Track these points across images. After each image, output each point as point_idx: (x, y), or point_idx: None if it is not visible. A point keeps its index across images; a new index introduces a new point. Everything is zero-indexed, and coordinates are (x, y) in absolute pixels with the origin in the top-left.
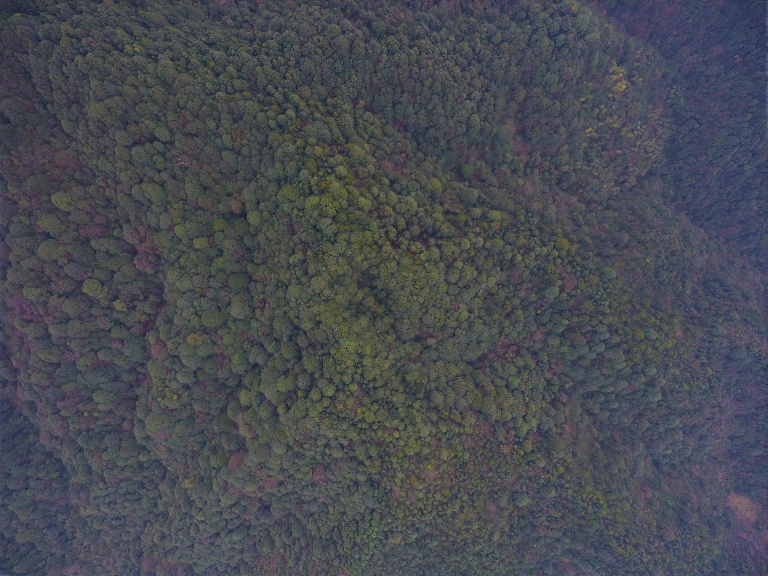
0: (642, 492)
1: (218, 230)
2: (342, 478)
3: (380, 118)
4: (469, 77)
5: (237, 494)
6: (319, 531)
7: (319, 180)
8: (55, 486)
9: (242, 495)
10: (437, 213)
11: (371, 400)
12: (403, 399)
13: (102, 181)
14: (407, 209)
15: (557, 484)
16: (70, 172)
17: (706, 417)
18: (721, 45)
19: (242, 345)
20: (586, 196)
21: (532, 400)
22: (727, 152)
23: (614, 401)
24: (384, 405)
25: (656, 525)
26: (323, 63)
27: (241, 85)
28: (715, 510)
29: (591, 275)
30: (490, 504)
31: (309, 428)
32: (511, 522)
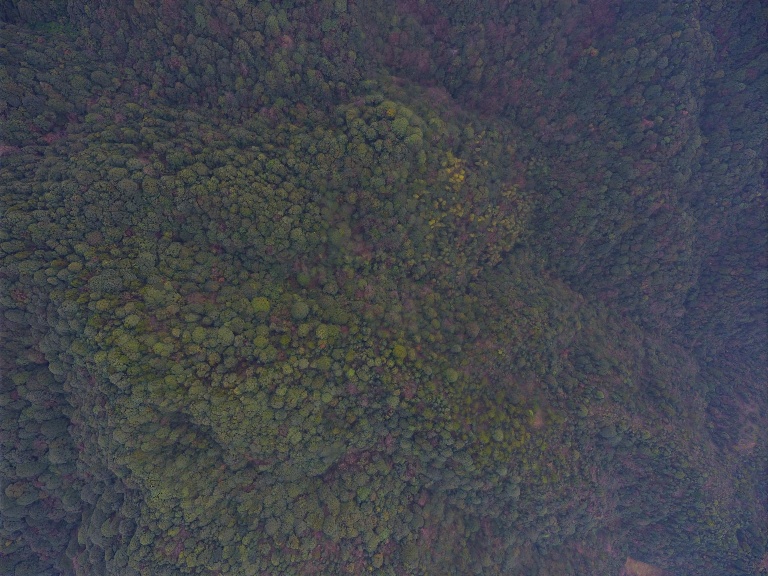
0: None
1: (20, 384)
2: None
3: (191, 246)
4: (284, 193)
5: None
6: None
7: (105, 335)
8: None
9: None
10: (258, 337)
11: (196, 540)
12: (230, 536)
13: None
14: (219, 342)
15: None
16: None
17: (581, 499)
18: (575, 115)
19: (72, 485)
20: (440, 285)
21: (386, 508)
22: (589, 223)
23: (476, 498)
24: (210, 544)
25: None
26: (111, 207)
27: (12, 247)
28: None
29: (430, 382)
30: None
31: None
32: None
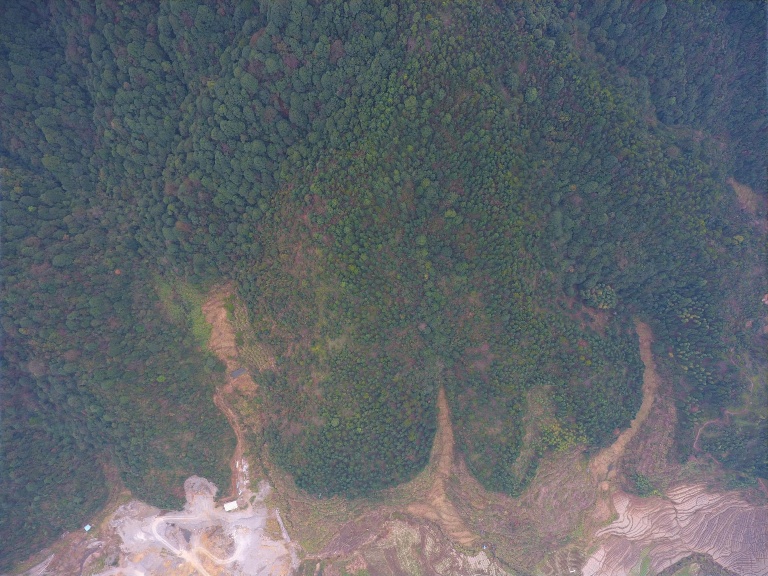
0: (647, 122)
1: None
2: (359, 47)
3: None
4: None
5: (257, 82)
6: (336, 127)
7: None
8: (80, 113)
9: (262, 87)
10: None
11: None
12: None
13: None
14: None
15: (566, 77)
16: None
17: (709, 63)
18: None
19: None
20: None
21: None
22: None
23: (621, 23)
24: None
25: None
26: None
27: None
28: None
29: None
30: (501, 86)
31: None
32: (521, 115)
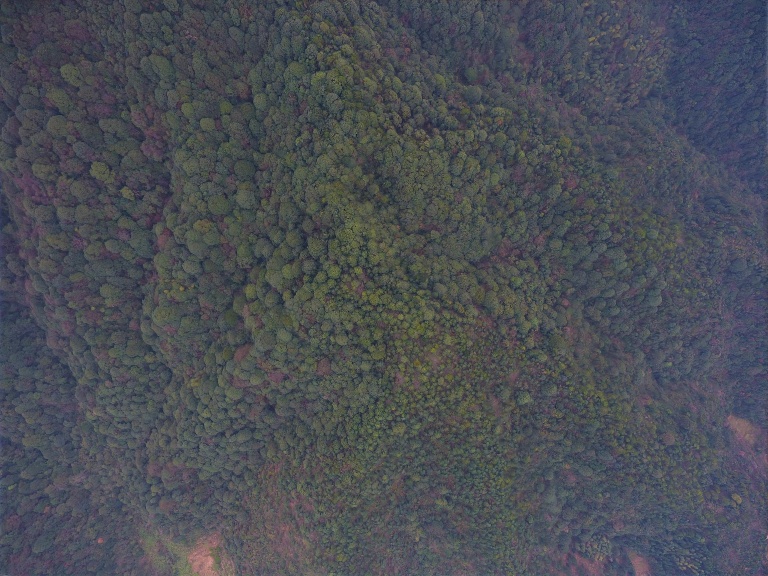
0: (642, 400)
1: (225, 113)
2: (346, 369)
3: (385, 11)
4: None
5: (242, 390)
6: (323, 429)
7: (325, 56)
8: (62, 391)
9: (247, 392)
10: (441, 106)
11: (376, 285)
12: (407, 285)
13: (111, 56)
14: (412, 97)
15: (559, 382)
16: (79, 45)
17: (706, 329)
18: None
19: (248, 237)
20: (588, 108)
21: (534, 301)
22: (729, 70)
23: (615, 307)
24: (388, 290)
25: (656, 431)
26: None
27: None
28: (714, 425)
29: (593, 174)
30: (492, 399)
31: (314, 309)
32: (513, 420)
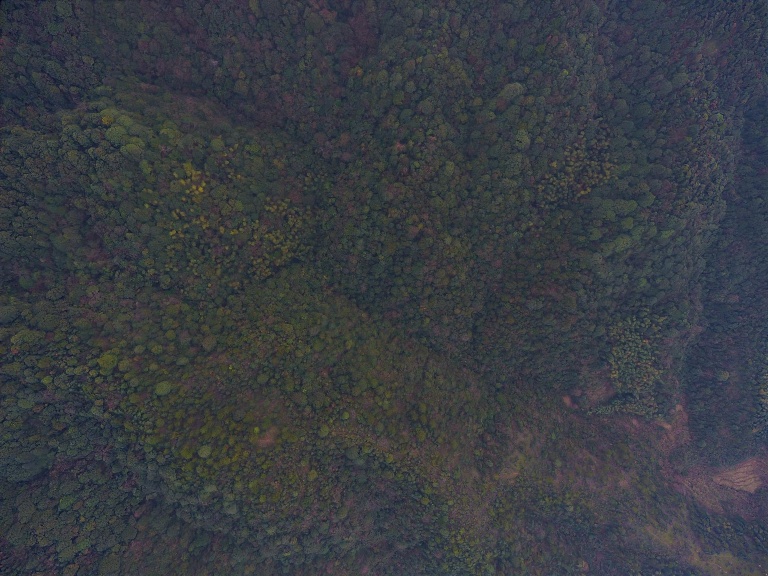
0: None
1: None
2: None
3: None
4: None
5: None
6: None
7: None
8: None
9: None
10: None
11: None
12: None
13: None
14: None
15: None
16: None
17: (321, 519)
18: (348, 133)
19: None
20: (188, 296)
21: (94, 518)
22: (356, 242)
23: (197, 512)
24: None
25: None
26: None
27: None
28: None
29: (133, 394)
30: None
31: None
32: None
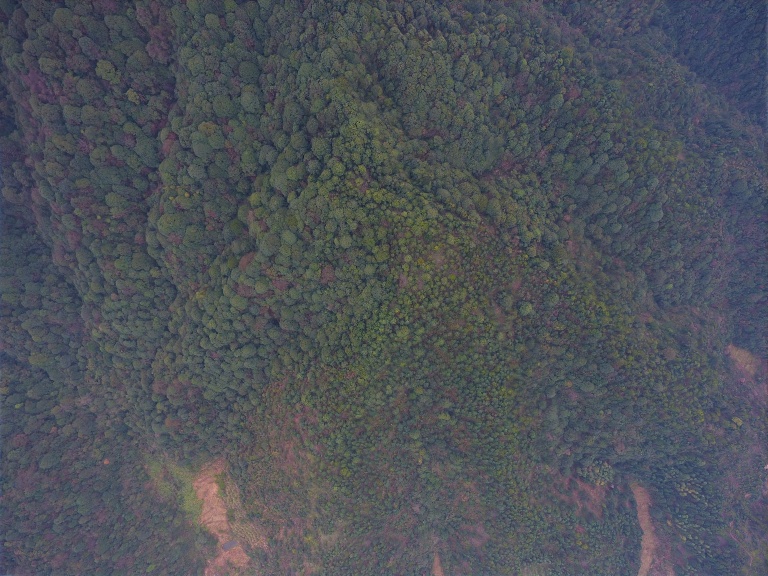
0: (644, 317)
1: (229, 11)
2: (350, 274)
3: None
4: None
5: (247, 300)
6: (327, 340)
7: None
8: (67, 310)
9: (252, 303)
10: (444, 12)
11: (379, 185)
12: (411, 186)
13: None
14: None
15: (561, 292)
16: None
17: (707, 250)
18: None
19: (252, 144)
20: (590, 29)
21: (536, 214)
22: None
23: (617, 223)
24: (392, 190)
25: (657, 347)
26: None
27: None
28: (715, 350)
29: (595, 83)
30: (495, 307)
31: (319, 206)
32: (515, 330)
